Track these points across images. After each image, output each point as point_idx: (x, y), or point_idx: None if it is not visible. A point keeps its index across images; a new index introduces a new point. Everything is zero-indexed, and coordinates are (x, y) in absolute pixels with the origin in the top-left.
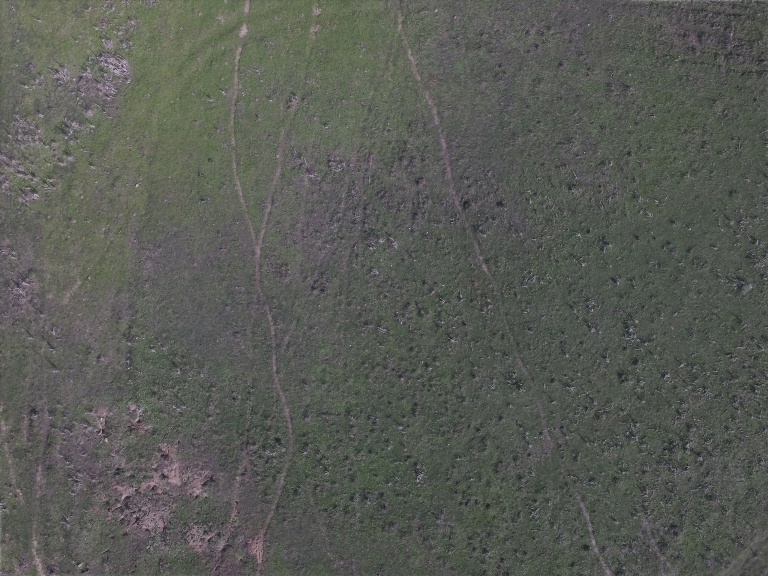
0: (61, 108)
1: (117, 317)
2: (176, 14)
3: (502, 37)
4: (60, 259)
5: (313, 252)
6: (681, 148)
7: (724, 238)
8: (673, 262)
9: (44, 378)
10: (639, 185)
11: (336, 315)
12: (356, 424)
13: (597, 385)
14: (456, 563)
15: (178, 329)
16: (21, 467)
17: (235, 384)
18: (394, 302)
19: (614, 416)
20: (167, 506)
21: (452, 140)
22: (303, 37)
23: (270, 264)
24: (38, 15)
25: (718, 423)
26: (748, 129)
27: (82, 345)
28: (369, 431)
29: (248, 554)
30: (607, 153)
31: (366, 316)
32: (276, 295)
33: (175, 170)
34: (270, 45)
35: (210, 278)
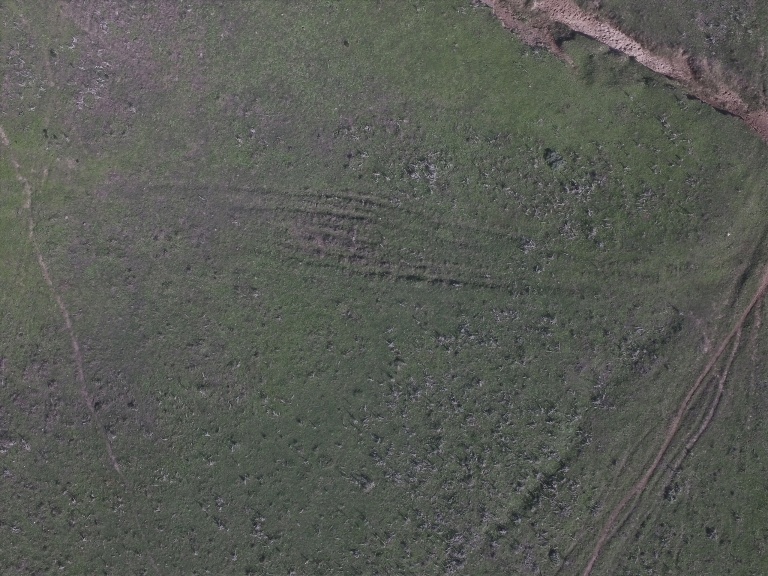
0: None
1: None
2: None
3: (131, 243)
4: None
5: None
6: (307, 348)
7: (349, 436)
8: (300, 460)
9: None
10: (266, 385)
11: None
12: None
13: None
14: None
15: None
16: None
17: None
18: (27, 502)
19: None
20: None
21: (84, 343)
22: None
23: None
24: None
25: None
26: (371, 329)
27: None
28: None
29: None
30: (235, 354)
31: None
32: None
33: None
34: None
35: None
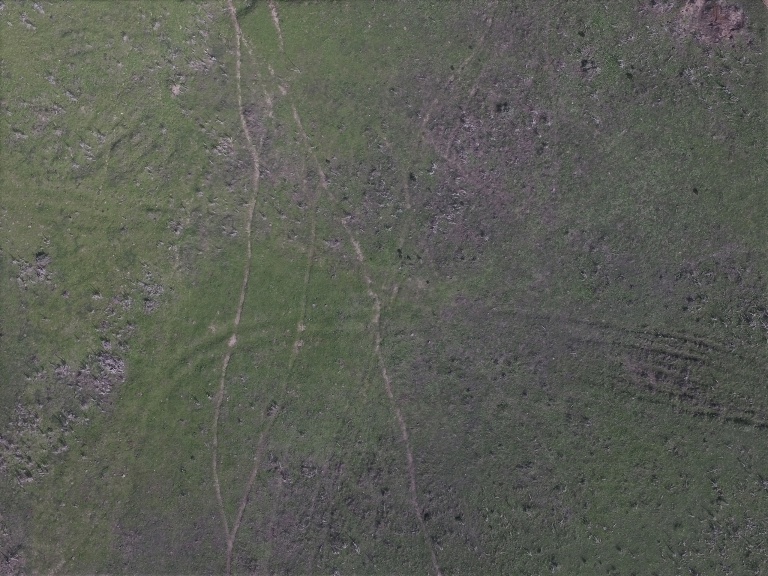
0: (60, 399)
1: None
2: (172, 321)
3: (472, 364)
4: (48, 539)
5: (281, 550)
6: (632, 480)
7: (666, 568)
8: None
9: None
10: (590, 511)
11: None
12: None
13: None
14: None
15: None
16: None
17: None
18: None
19: None
20: None
21: (418, 455)
22: (287, 350)
23: (241, 558)
24: (45, 313)
25: None
26: (696, 468)
27: None
28: None
29: None
30: (562, 479)
31: None
32: None
33: (160, 464)
34: (256, 355)
35: (184, 566)
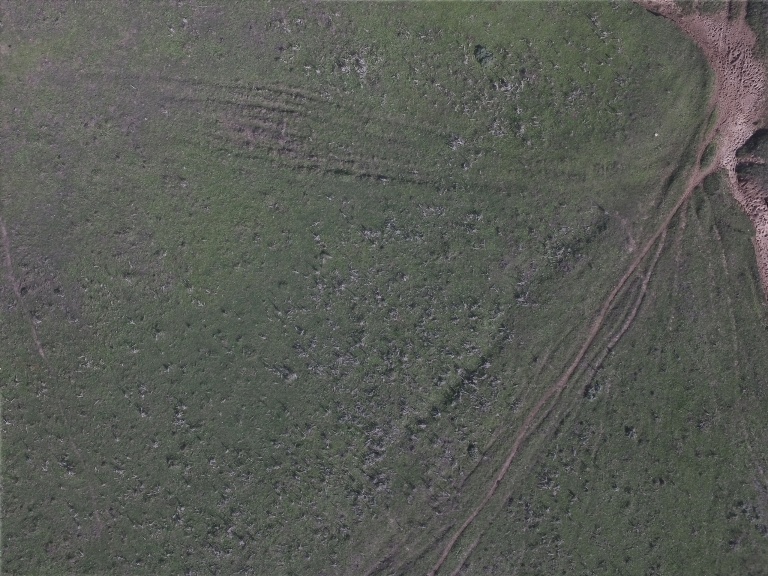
0: None
1: None
2: None
3: (61, 129)
4: None
5: None
6: (234, 239)
7: (273, 328)
8: (223, 350)
9: None
10: (192, 275)
11: None
12: None
13: (147, 469)
14: None
15: None
16: None
17: None
18: None
19: (162, 499)
20: None
21: (12, 228)
22: None
23: None
24: None
25: (261, 508)
26: (298, 222)
27: None
28: None
29: None
30: (162, 243)
31: None
32: None
33: None
34: None
35: None
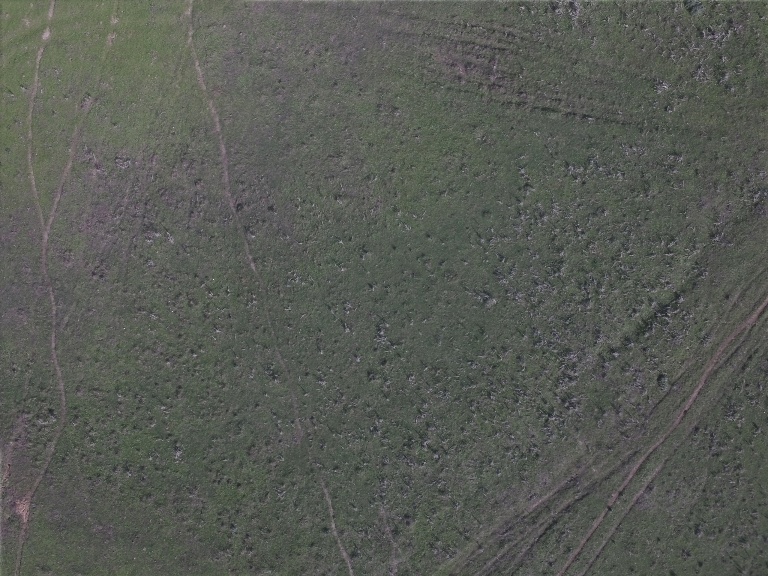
0: None
1: None
2: None
3: (283, 55)
4: None
5: (96, 240)
6: (441, 168)
7: (475, 254)
8: (426, 273)
9: None
10: (400, 200)
11: (112, 300)
12: (124, 401)
13: (348, 381)
14: (205, 536)
15: None
16: None
17: (16, 357)
18: (167, 292)
19: (361, 411)
20: None
21: (231, 146)
22: (100, 42)
23: (56, 249)
24: None
25: (455, 424)
26: (504, 155)
27: None
28: (135, 409)
29: (15, 513)
30: (373, 168)
31: (140, 303)
32: (59, 277)
33: None
34: (70, 48)
35: (0, 258)
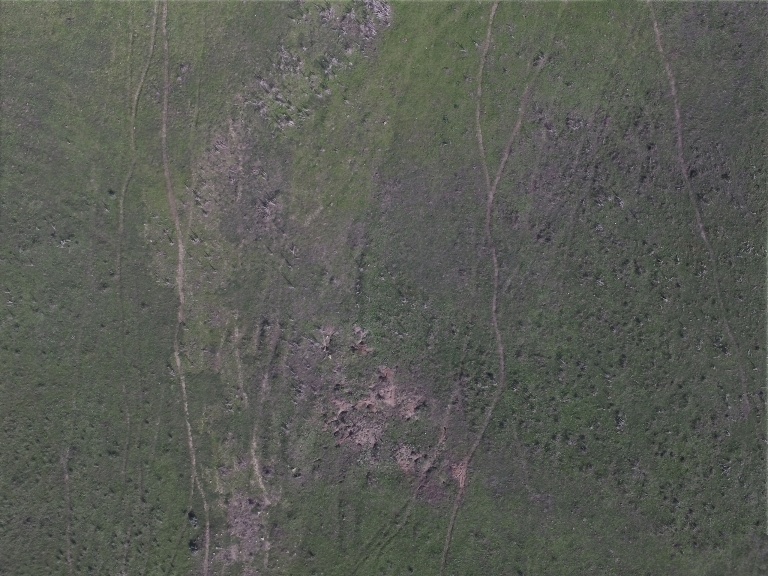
0: (323, 43)
1: (352, 244)
2: None
3: (745, 18)
4: (306, 184)
5: (543, 203)
6: None
7: None
8: None
9: (279, 293)
10: None
11: (558, 264)
12: (565, 368)
13: None
14: (647, 509)
15: (408, 261)
16: (249, 373)
17: (455, 318)
18: (614, 258)
19: None
20: (380, 424)
21: (686, 111)
22: None
23: (501, 209)
24: None
25: None
26: None
27: (318, 266)
28: (577, 376)
29: (452, 478)
30: None
31: (586, 268)
32: (503, 239)
33: (422, 112)
34: (524, 4)
35: (443, 217)
